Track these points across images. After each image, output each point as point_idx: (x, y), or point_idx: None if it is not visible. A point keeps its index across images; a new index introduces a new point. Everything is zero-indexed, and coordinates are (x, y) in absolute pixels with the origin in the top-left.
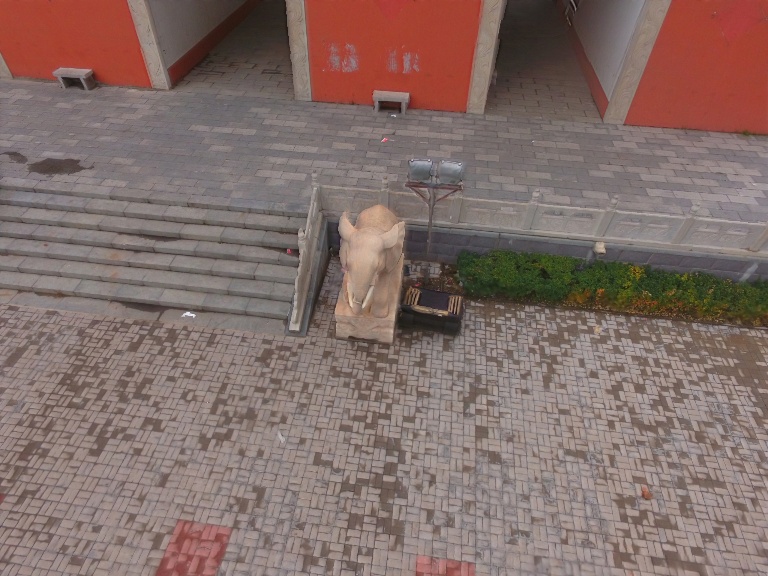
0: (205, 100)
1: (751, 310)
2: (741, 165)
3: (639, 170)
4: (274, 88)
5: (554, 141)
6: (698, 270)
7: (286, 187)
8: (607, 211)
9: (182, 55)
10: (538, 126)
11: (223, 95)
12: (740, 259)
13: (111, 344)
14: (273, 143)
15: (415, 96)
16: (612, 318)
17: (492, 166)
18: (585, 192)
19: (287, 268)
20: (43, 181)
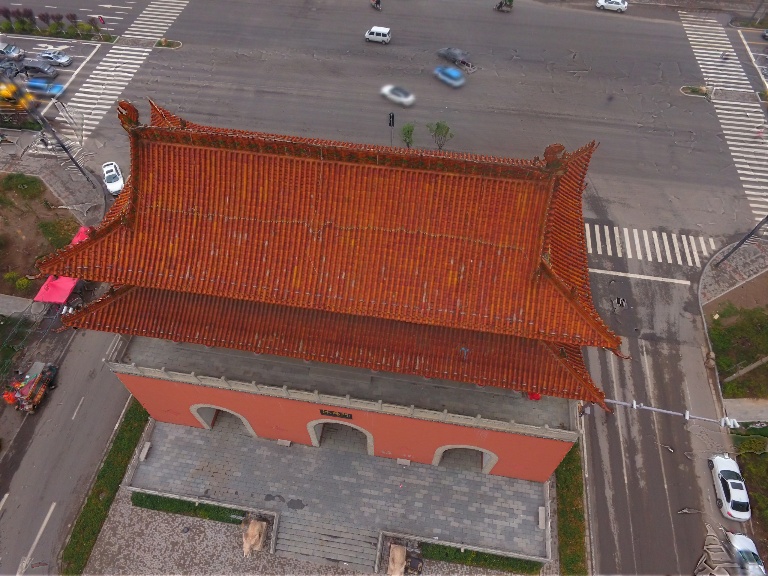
0: (334, 455)
1: (503, 569)
2: (521, 503)
3: (485, 506)
4: (359, 444)
5: (460, 487)
6: (492, 554)
7: (370, 517)
8: None
9: (322, 428)
10: (457, 475)
11: (340, 451)
12: (502, 555)
13: (327, 575)
14: (363, 489)
15: (413, 460)
16: (465, 567)
17: (437, 504)
18: (464, 520)
19: (373, 550)
20: (295, 513)
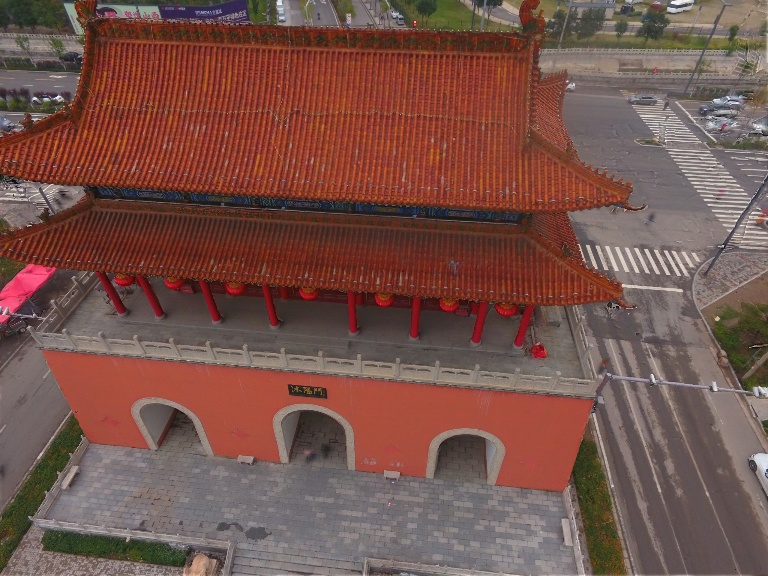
0: (307, 472)
1: None
2: (539, 517)
3: (496, 523)
4: (337, 458)
5: (463, 501)
6: None
7: (352, 544)
8: (472, 572)
9: (293, 440)
10: (457, 488)
11: (314, 467)
12: None
13: None
14: (342, 510)
15: (402, 472)
16: None
17: (435, 524)
18: (471, 542)
19: None
20: (255, 545)
